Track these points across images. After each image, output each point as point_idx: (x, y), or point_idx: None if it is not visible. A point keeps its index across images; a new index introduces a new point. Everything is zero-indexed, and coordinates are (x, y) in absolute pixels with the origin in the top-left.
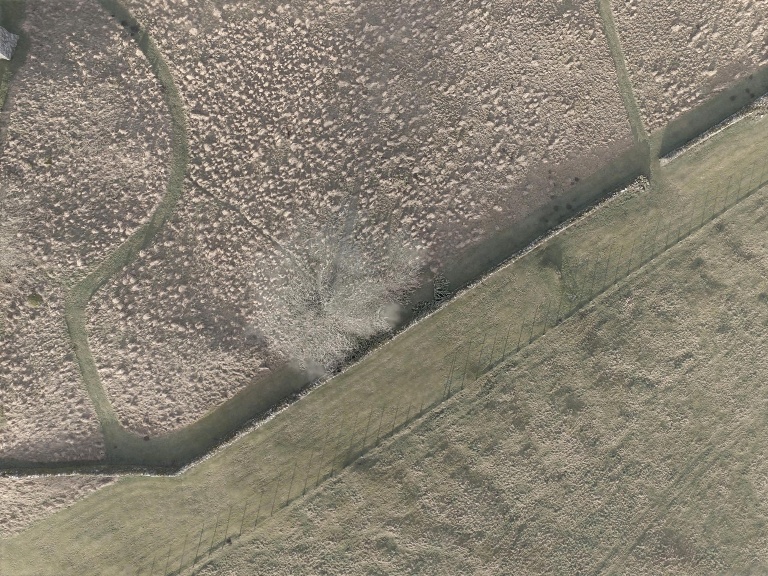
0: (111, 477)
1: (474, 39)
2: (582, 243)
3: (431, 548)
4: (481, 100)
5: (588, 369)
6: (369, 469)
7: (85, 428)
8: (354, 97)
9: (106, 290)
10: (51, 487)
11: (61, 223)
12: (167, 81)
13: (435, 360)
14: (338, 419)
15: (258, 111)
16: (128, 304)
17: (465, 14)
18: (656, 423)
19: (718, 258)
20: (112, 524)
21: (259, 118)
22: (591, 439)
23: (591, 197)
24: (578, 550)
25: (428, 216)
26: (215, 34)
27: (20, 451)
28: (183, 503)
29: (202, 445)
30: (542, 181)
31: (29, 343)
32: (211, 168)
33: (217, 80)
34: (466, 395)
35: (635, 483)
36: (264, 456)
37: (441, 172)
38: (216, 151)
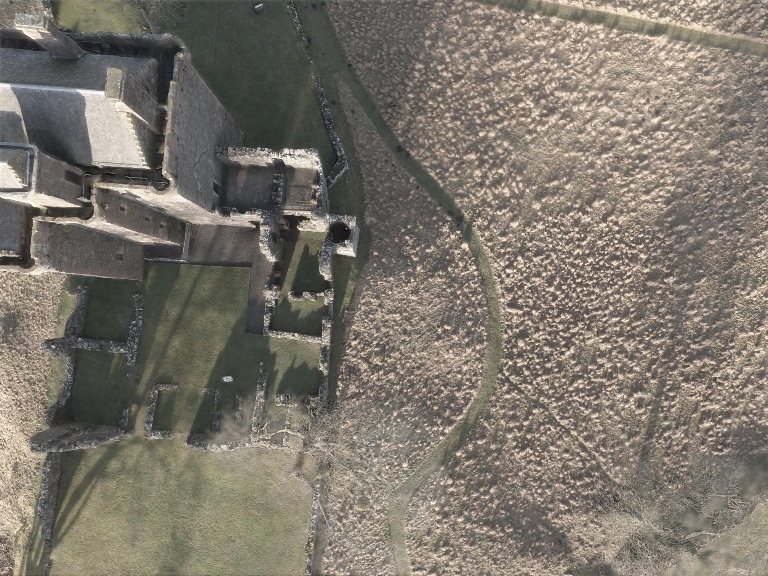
0: None
1: None
2: None
3: None
4: None
5: None
6: None
7: None
8: (661, 297)
9: (425, 491)
10: None
11: (389, 422)
12: (486, 273)
13: None
14: None
15: (569, 307)
16: (445, 505)
17: None
18: None
19: None
20: None
21: (571, 314)
22: None
23: None
24: None
25: (725, 421)
26: (534, 227)
27: None
28: None
29: None
30: None
31: (354, 546)
32: (523, 363)
33: (532, 273)
34: None
35: None
36: None
37: (738, 376)
38: (528, 346)
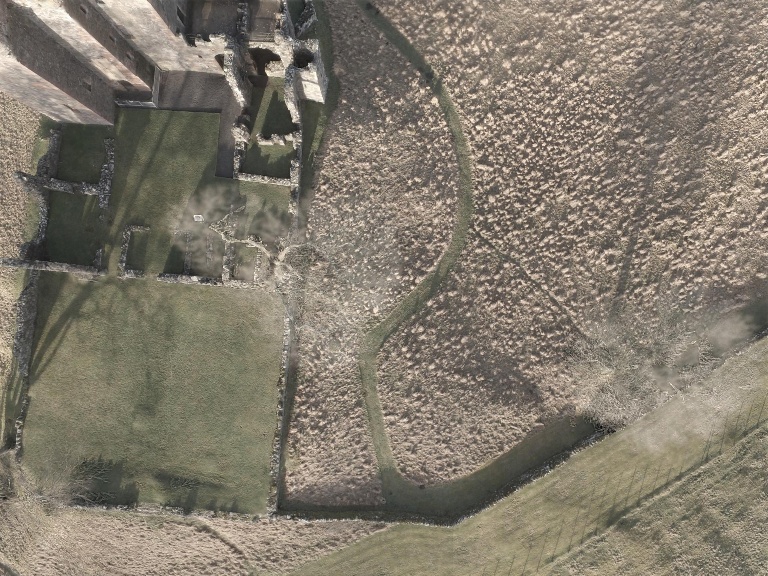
0: (385, 523)
1: (748, 105)
2: None
3: None
4: (750, 166)
5: None
6: (630, 529)
7: (365, 473)
8: (632, 156)
9: (396, 338)
10: (328, 530)
11: (360, 269)
12: (456, 130)
13: (696, 424)
14: (604, 478)
15: (540, 165)
16: (416, 353)
17: (741, 80)
18: None
19: None
20: (381, 569)
21: (541, 172)
22: None
23: None
24: None
25: (696, 280)
26: (504, 85)
27: (306, 494)
28: (452, 553)
29: (476, 497)
30: None
31: (326, 388)
32: (493, 219)
33: (503, 131)
34: (723, 460)
35: None
36: (534, 511)
37: (710, 236)
38: (499, 203)
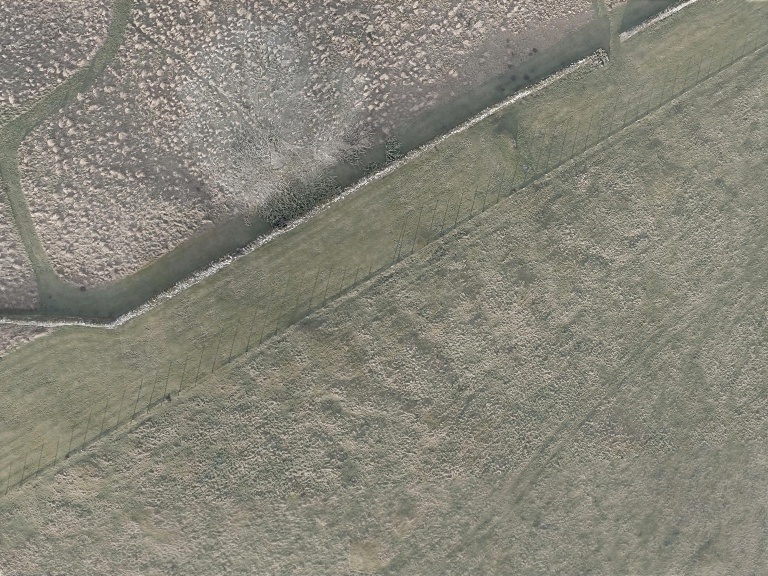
0: (45, 327)
1: None
2: (539, 114)
3: (377, 412)
4: None
5: (541, 242)
6: (315, 329)
7: (18, 275)
8: None
9: (41, 131)
10: None
11: None
12: None
13: (385, 223)
14: (284, 277)
15: None
16: (64, 147)
17: None
18: (609, 301)
19: (676, 139)
20: (46, 377)
21: None
22: (543, 313)
23: (549, 69)
24: (527, 423)
25: (381, 77)
26: None
27: None
28: (121, 357)
29: (141, 297)
30: (500, 49)
31: None
32: (155, 15)
33: None
34: (416, 260)
35: (586, 360)
36: (206, 311)
37: (396, 33)
38: None
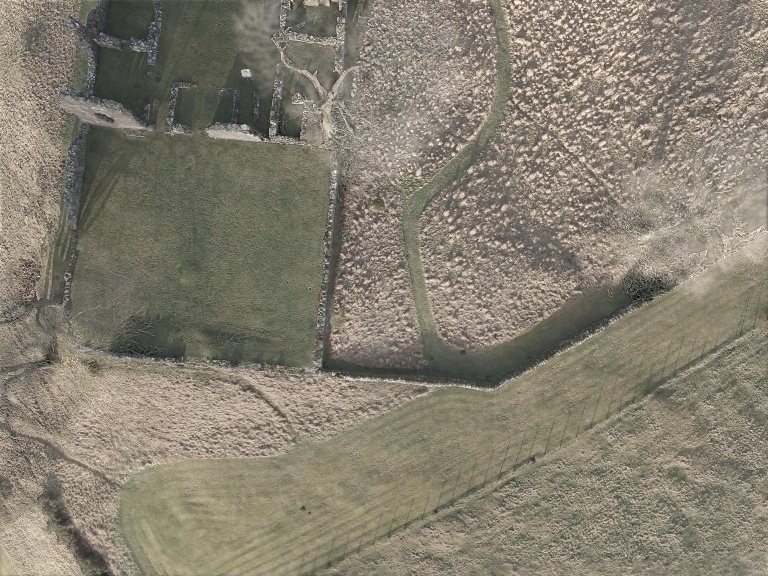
0: (427, 387)
1: None
2: None
3: (718, 481)
4: None
5: None
6: (667, 399)
7: (408, 337)
8: (666, 35)
9: (438, 202)
10: (371, 393)
11: (403, 132)
12: (495, 4)
13: (731, 298)
14: (641, 348)
15: (577, 41)
16: (457, 218)
17: None
18: None
19: None
20: (422, 434)
21: (578, 48)
22: None
23: None
24: None
25: (729, 157)
26: None
27: (350, 354)
28: (492, 418)
29: (516, 362)
30: None
31: (370, 247)
32: (532, 93)
33: (540, 7)
34: (757, 335)
35: None
36: (573, 378)
37: (742, 116)
38: (537, 77)
